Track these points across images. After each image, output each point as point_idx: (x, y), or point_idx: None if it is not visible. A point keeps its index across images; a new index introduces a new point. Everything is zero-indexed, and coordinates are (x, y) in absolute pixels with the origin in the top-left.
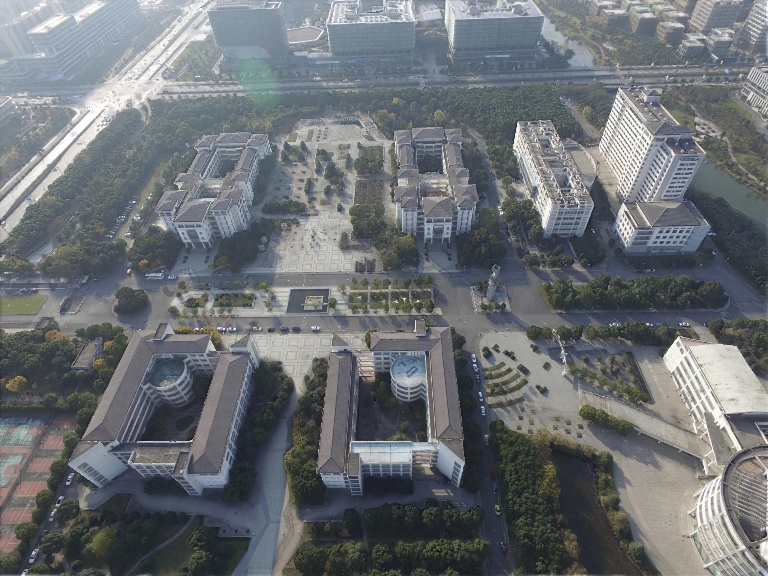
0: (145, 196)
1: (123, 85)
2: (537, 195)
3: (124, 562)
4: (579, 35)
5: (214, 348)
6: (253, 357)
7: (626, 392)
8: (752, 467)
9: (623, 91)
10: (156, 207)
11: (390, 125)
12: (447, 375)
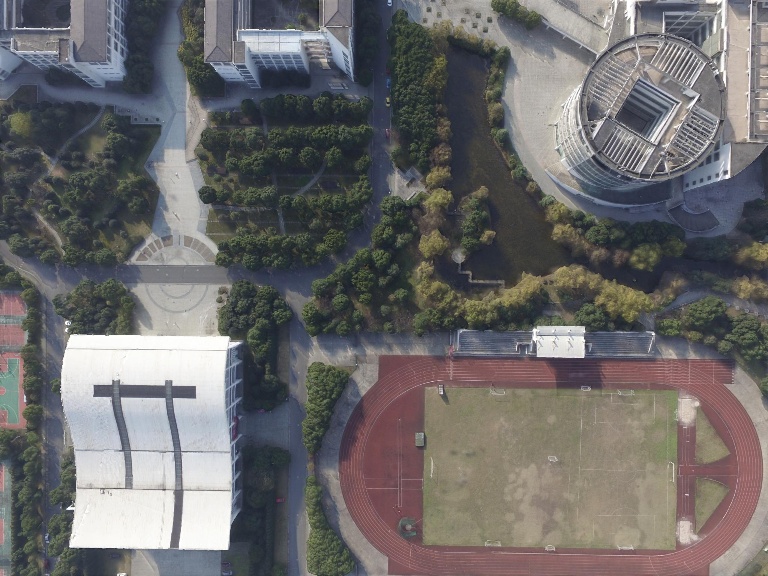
0: None
1: None
2: None
3: (51, 143)
4: None
5: None
6: None
7: None
8: (629, 56)
9: None
10: None
11: None
12: None
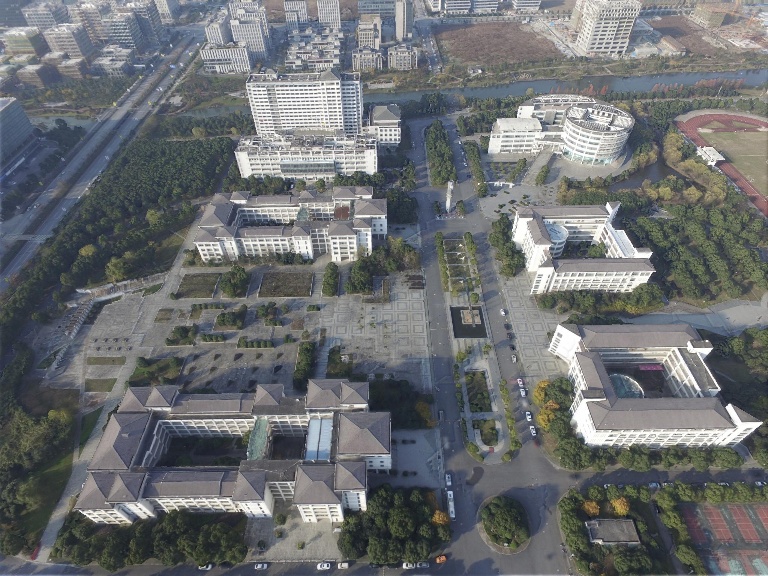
0: None
1: None
2: (340, 166)
3: None
4: None
5: None
6: None
7: None
8: None
9: (254, 83)
10: None
11: (142, 263)
12: (561, 207)
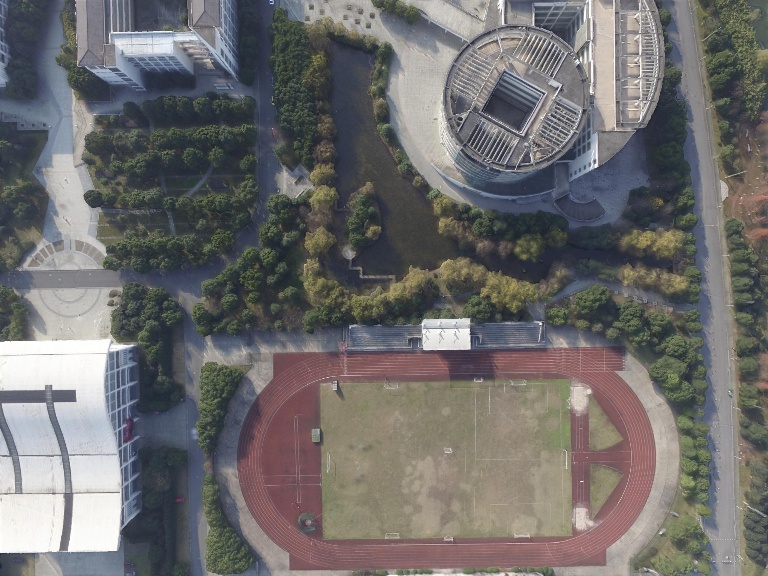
0: None
1: None
2: None
3: None
4: None
5: None
6: None
7: None
8: (494, 49)
9: None
10: None
11: None
12: None
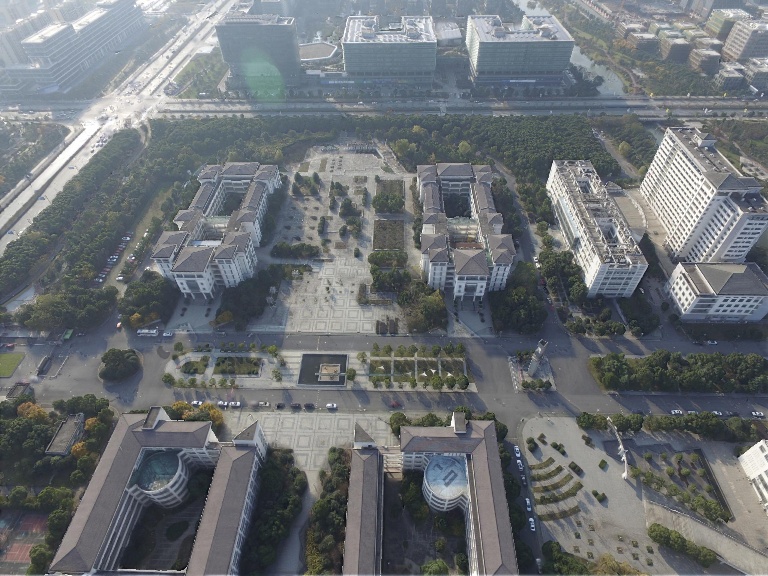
0: (141, 232)
1: (122, 101)
2: (579, 247)
3: None
4: (607, 59)
5: (214, 436)
6: (260, 447)
7: (703, 508)
8: None
9: (673, 132)
10: (152, 246)
11: (410, 156)
12: (495, 490)
